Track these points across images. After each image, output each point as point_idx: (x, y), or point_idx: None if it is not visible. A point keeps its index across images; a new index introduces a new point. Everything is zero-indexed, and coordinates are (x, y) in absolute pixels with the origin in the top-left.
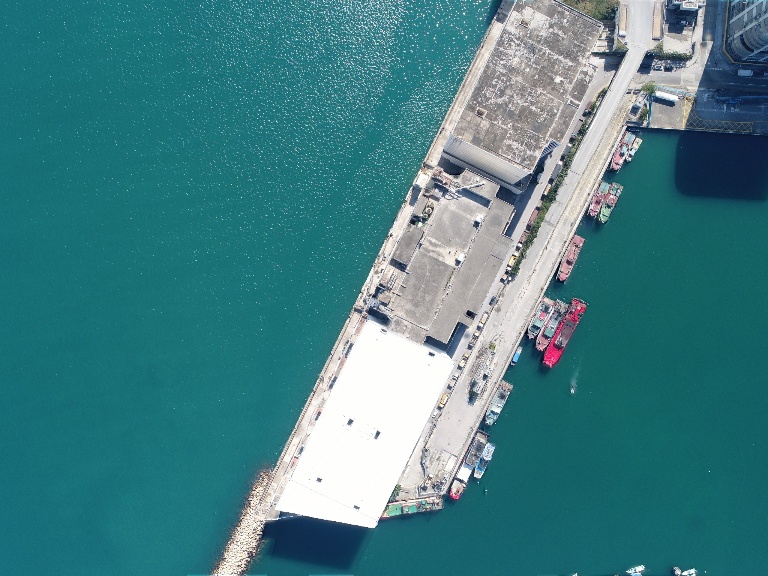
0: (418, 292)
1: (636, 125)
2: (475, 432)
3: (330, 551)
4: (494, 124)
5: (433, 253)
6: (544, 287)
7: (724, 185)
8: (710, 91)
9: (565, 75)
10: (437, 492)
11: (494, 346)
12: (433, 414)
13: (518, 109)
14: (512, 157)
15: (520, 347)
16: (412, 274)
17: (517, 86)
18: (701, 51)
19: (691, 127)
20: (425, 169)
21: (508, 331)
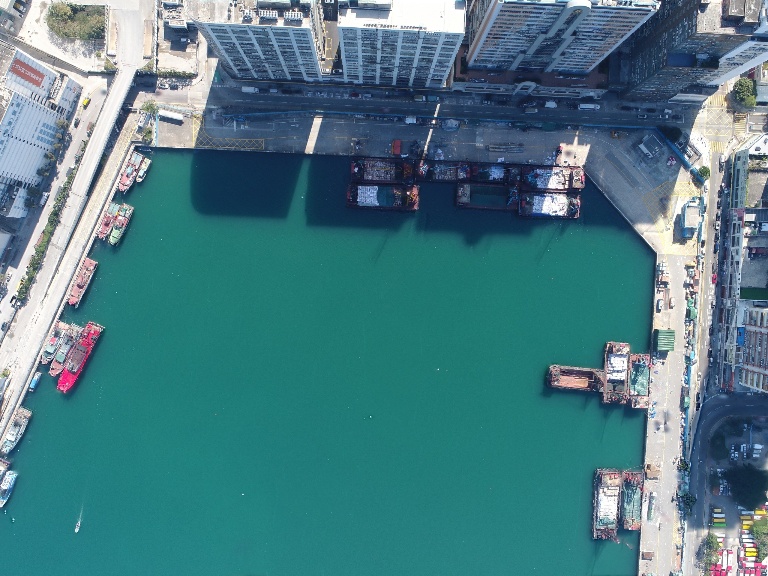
0: None
1: (144, 145)
2: None
3: None
4: None
5: None
6: (58, 311)
7: (246, 203)
8: (219, 109)
9: None
10: None
11: (4, 373)
12: None
13: None
14: None
15: (38, 373)
16: None
17: None
18: (207, 68)
19: (201, 145)
20: None
21: (23, 357)
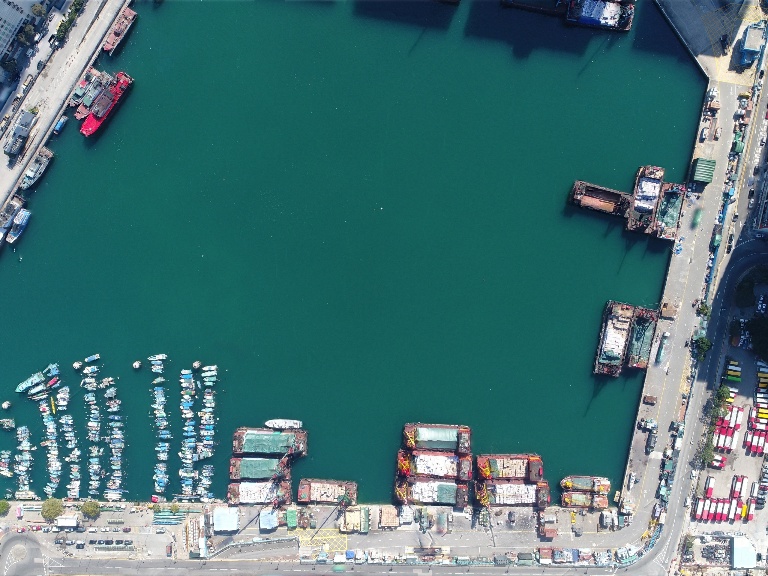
0: None
1: None
2: (12, 196)
3: None
4: None
5: None
6: (92, 57)
7: None
8: None
9: None
10: None
11: (33, 109)
12: None
13: None
14: None
15: (65, 116)
16: None
17: None
18: None
19: None
20: None
21: (53, 98)
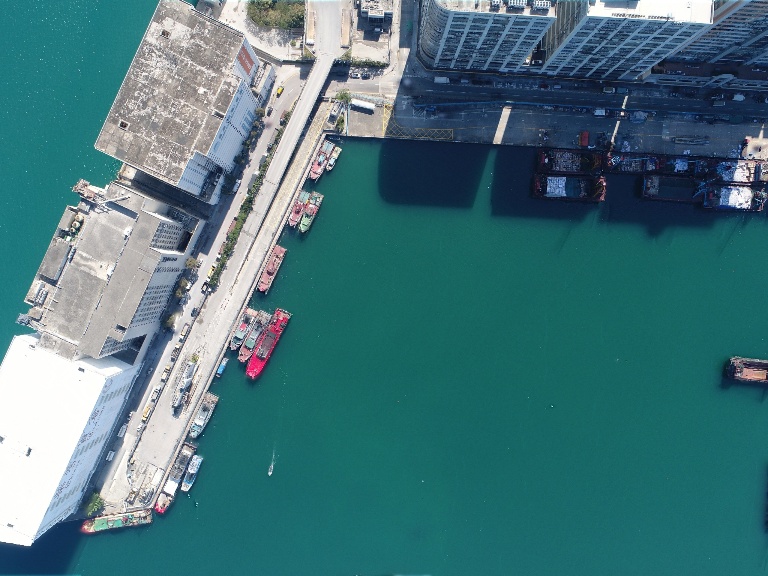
0: (71, 307)
1: (335, 133)
2: (181, 445)
3: (40, 567)
4: (138, 136)
5: (84, 267)
6: (247, 298)
7: (431, 193)
8: (409, 98)
9: (208, 86)
10: (143, 506)
11: (194, 358)
12: (137, 427)
13: (162, 121)
14: (157, 169)
15: (225, 358)
16: (64, 289)
17: (160, 98)
18: (398, 58)
19: (391, 135)
20: (121, 180)
21: (211, 343)
